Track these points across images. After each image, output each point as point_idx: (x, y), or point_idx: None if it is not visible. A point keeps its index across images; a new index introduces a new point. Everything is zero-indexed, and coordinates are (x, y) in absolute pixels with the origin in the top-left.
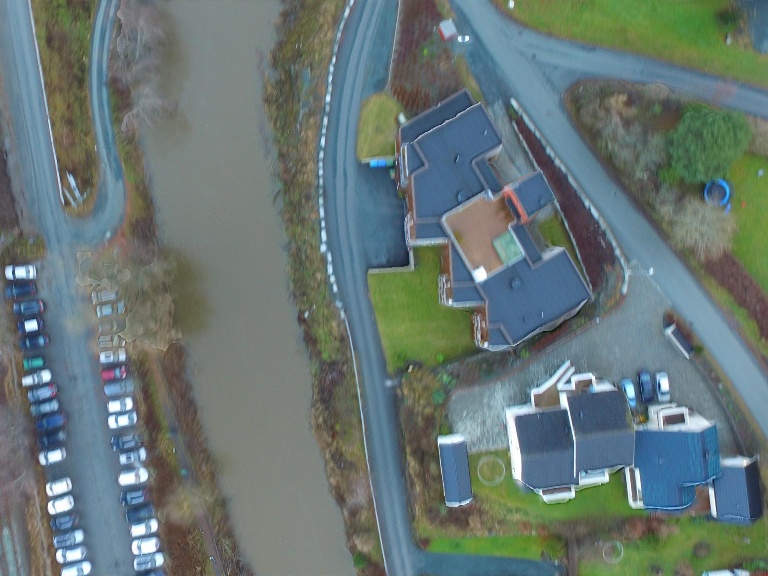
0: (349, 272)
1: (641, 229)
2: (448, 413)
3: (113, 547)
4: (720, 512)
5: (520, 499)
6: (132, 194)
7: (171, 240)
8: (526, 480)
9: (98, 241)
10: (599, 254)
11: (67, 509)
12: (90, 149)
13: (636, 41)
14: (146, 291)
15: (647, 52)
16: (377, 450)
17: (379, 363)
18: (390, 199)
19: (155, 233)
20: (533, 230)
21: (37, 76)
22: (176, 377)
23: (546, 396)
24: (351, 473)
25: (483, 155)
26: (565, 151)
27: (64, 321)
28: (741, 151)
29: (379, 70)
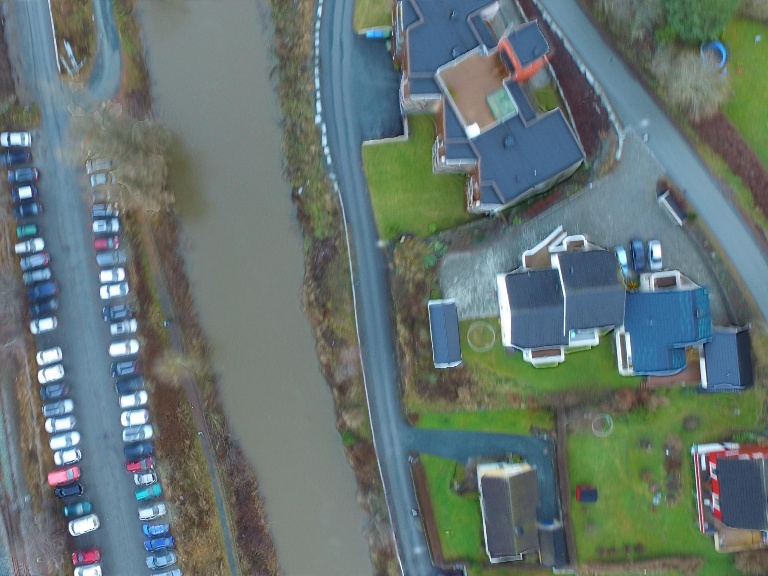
0: (343, 145)
1: (636, 95)
2: (439, 278)
3: (102, 419)
4: (710, 381)
5: (510, 368)
6: (128, 65)
7: (166, 112)
8: (515, 339)
9: (94, 111)
10: (594, 121)
11: (57, 378)
12: (87, 18)
13: None
14: (139, 142)
15: None
16: (368, 325)
17: (372, 237)
18: (386, 72)
19: (151, 106)
20: (527, 89)
21: None
22: (169, 250)
23: (537, 259)
24: (342, 350)
25: (479, 11)
26: (562, 17)
27: (58, 191)
28: (738, 10)
29: None
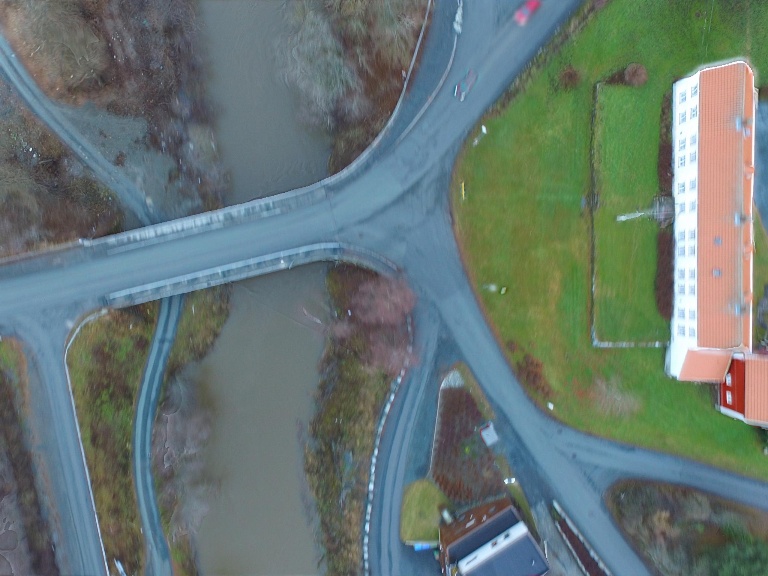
0: None
1: None
2: None
3: None
4: None
5: None
6: (179, 573)
7: None
8: None
9: None
10: None
11: None
12: (136, 533)
13: (675, 445)
14: None
15: (686, 455)
16: None
17: None
18: (434, 575)
19: None
20: None
21: (83, 475)
22: None
23: None
24: None
25: None
26: (608, 552)
27: None
28: None
29: (421, 458)
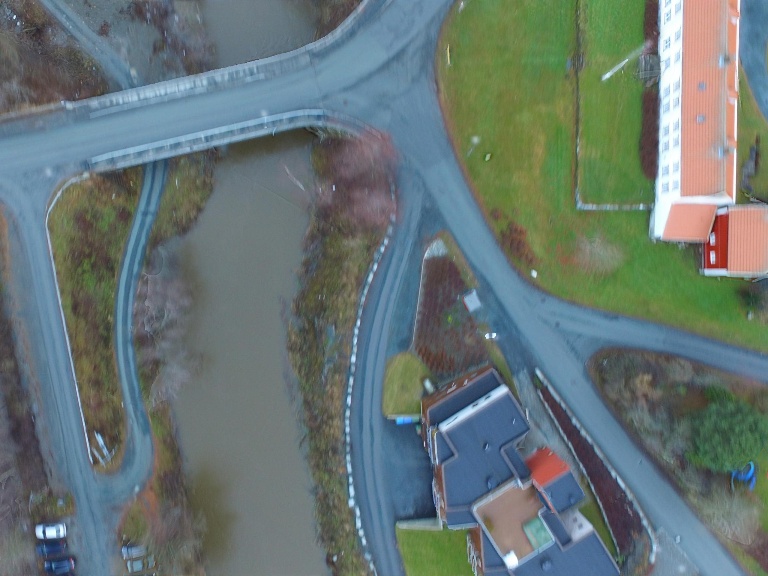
0: (377, 524)
1: (667, 497)
2: None
3: None
4: None
5: None
6: (160, 448)
7: (199, 491)
8: None
9: (127, 495)
10: (626, 520)
11: None
12: (117, 406)
13: (658, 312)
14: None
15: (669, 323)
16: None
17: None
18: (416, 452)
19: (183, 483)
20: None
21: (64, 344)
22: None
23: None
24: None
25: (512, 442)
26: (590, 420)
27: (95, 575)
28: (766, 435)
29: (403, 330)
